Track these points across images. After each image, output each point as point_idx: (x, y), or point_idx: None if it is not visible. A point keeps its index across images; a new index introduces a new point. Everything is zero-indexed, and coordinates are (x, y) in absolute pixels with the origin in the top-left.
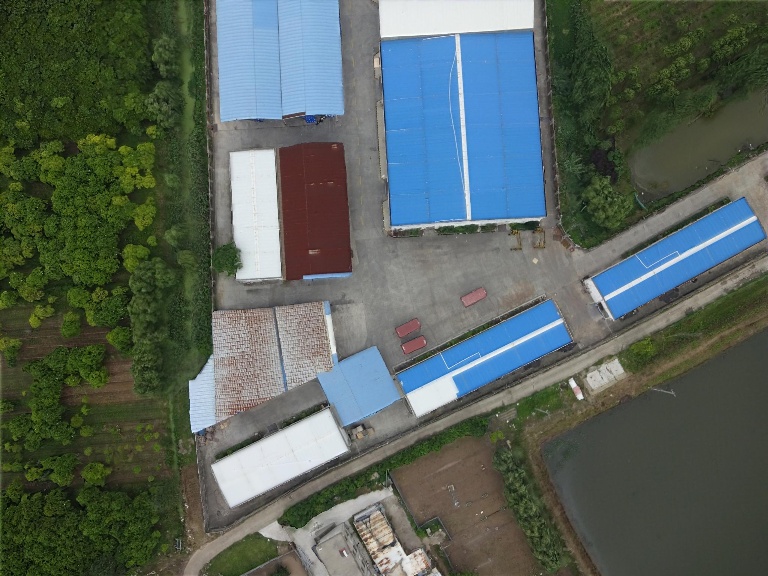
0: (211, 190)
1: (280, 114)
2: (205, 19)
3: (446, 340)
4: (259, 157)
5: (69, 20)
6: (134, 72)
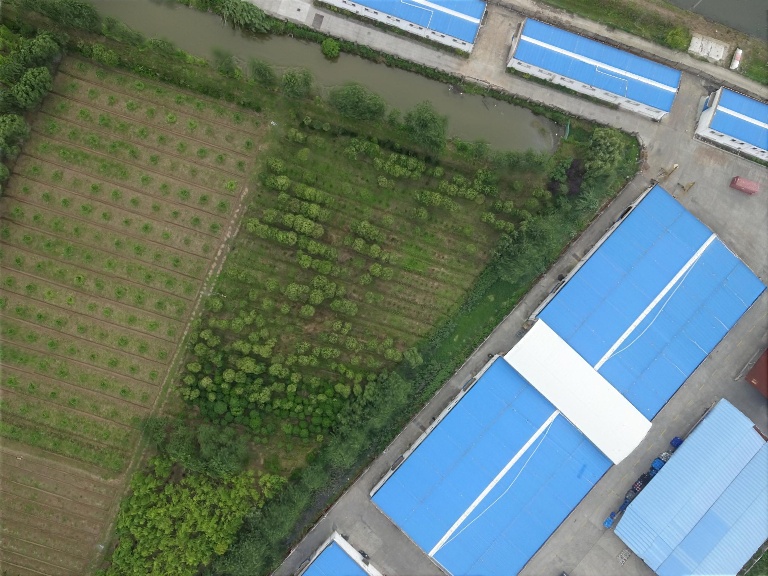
0: None
1: (767, 445)
2: None
3: None
4: None
5: None
6: None
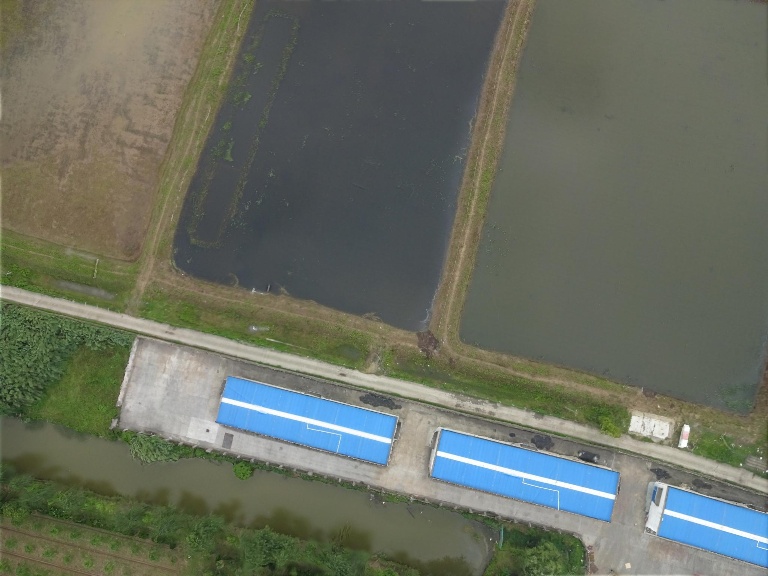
0: None
1: None
2: None
3: (760, 569)
4: None
5: None
6: None
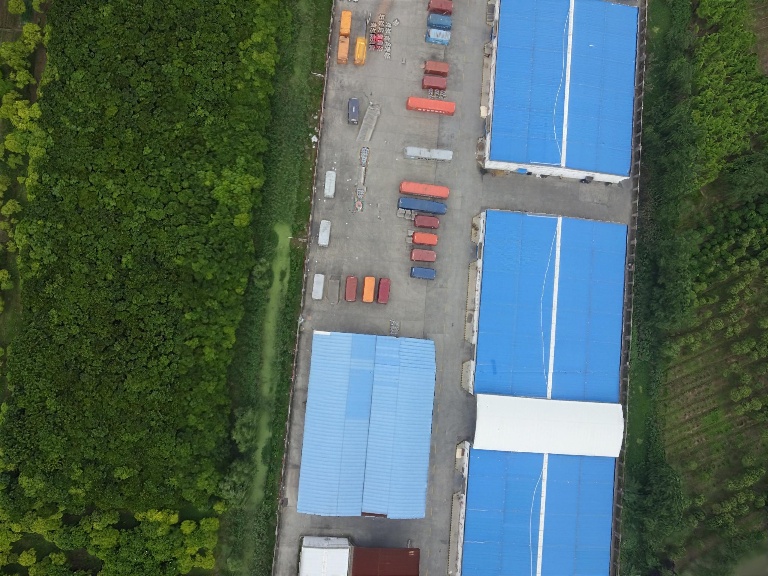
0: (273, 572)
1: (360, 510)
2: (290, 384)
3: None
4: (332, 556)
5: (149, 387)
6: (212, 449)
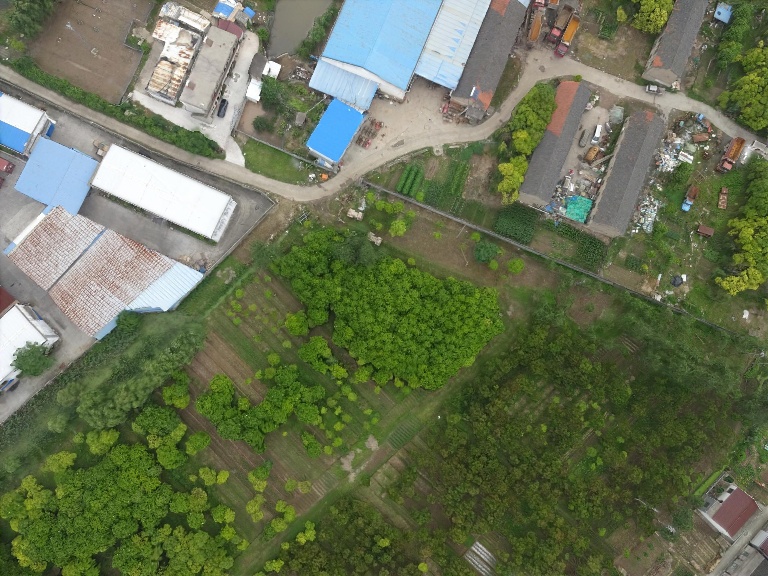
0: None
1: None
2: None
3: None
4: None
5: None
6: None
